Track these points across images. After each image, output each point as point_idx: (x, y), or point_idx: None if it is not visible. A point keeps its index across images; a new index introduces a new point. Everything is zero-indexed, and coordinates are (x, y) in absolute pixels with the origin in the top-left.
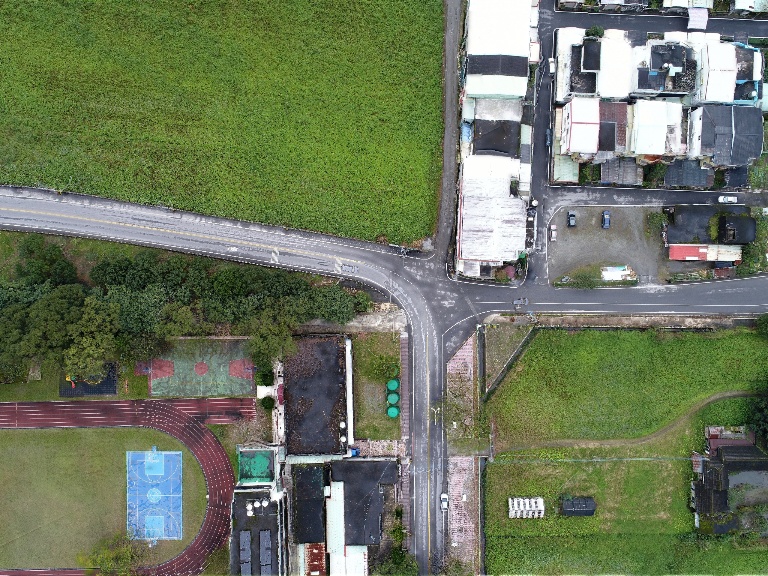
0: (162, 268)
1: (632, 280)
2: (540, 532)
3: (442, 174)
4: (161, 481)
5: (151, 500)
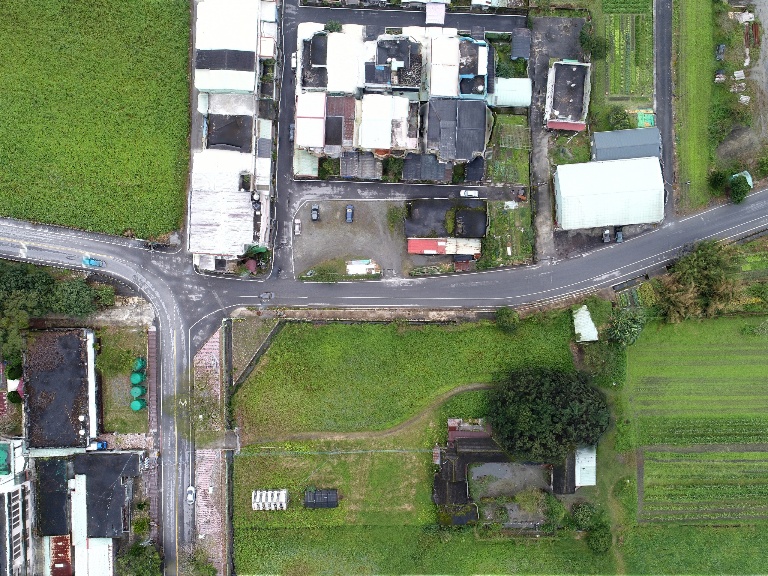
0: None
1: (374, 274)
2: (286, 524)
3: (189, 169)
4: None
5: None
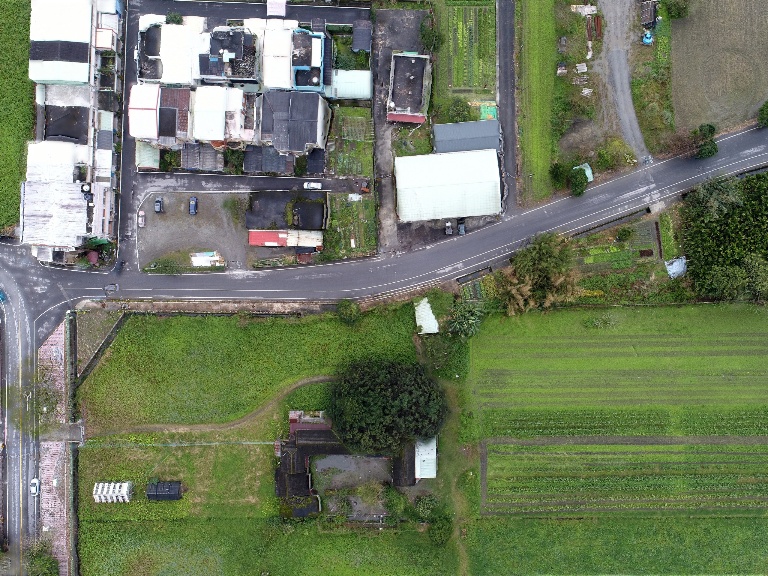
0: None
1: (217, 266)
2: (130, 516)
3: None
4: None
5: None
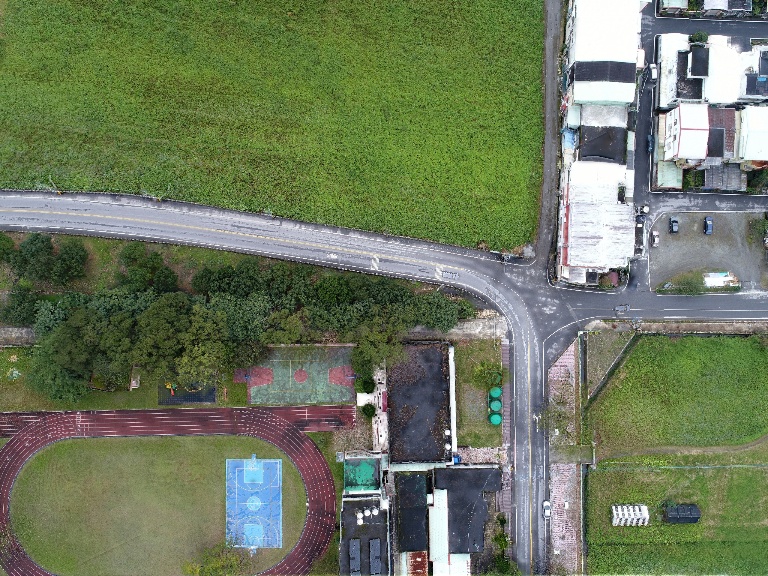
0: (267, 275)
1: (735, 286)
2: (643, 540)
3: (543, 180)
4: (260, 489)
5: (250, 508)
